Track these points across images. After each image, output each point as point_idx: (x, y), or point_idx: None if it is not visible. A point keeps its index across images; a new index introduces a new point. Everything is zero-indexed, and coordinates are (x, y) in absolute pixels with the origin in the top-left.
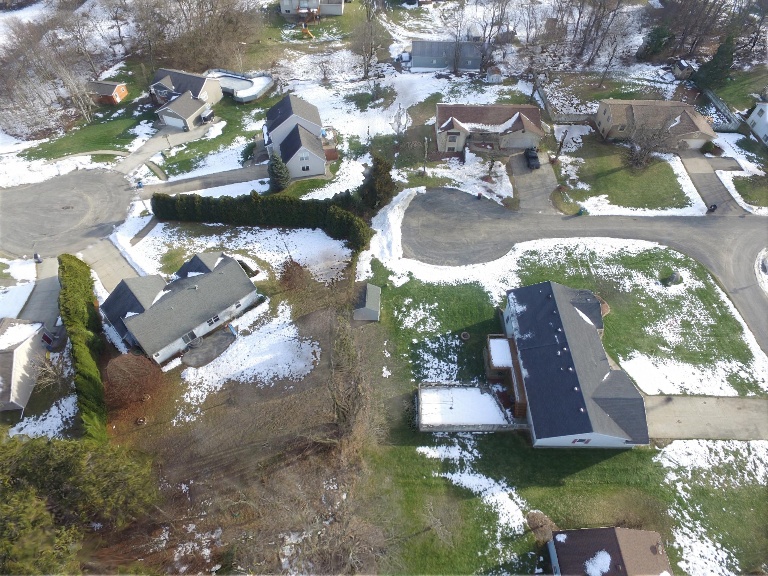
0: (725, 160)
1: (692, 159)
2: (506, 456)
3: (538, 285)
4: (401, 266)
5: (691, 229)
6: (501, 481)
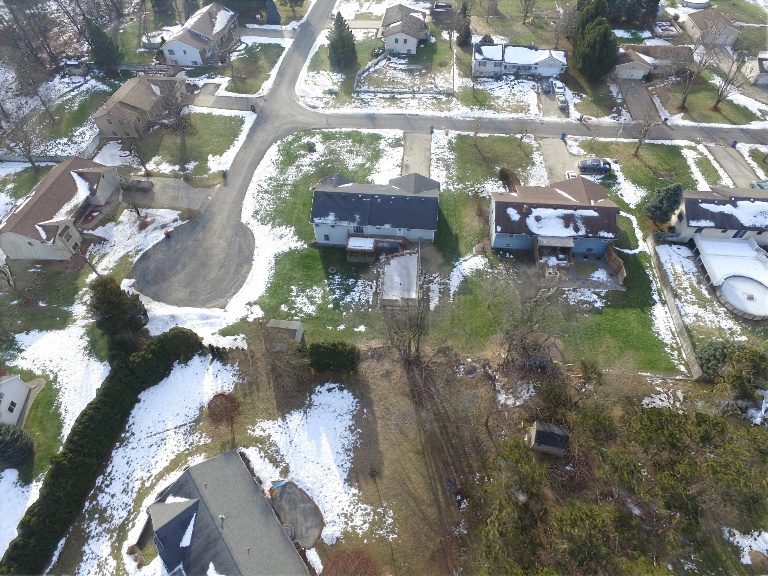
0: (206, 87)
1: (196, 100)
2: (438, 258)
3: (315, 199)
4: (236, 310)
5: (267, 125)
6: (455, 264)
